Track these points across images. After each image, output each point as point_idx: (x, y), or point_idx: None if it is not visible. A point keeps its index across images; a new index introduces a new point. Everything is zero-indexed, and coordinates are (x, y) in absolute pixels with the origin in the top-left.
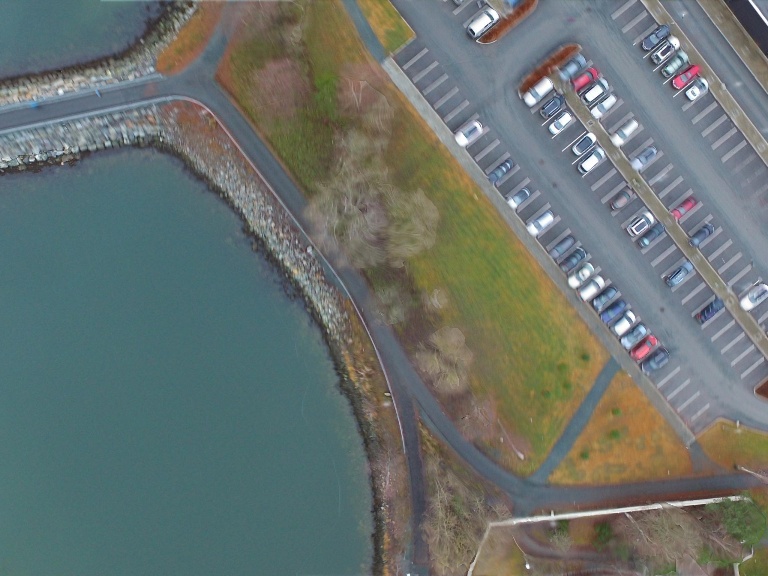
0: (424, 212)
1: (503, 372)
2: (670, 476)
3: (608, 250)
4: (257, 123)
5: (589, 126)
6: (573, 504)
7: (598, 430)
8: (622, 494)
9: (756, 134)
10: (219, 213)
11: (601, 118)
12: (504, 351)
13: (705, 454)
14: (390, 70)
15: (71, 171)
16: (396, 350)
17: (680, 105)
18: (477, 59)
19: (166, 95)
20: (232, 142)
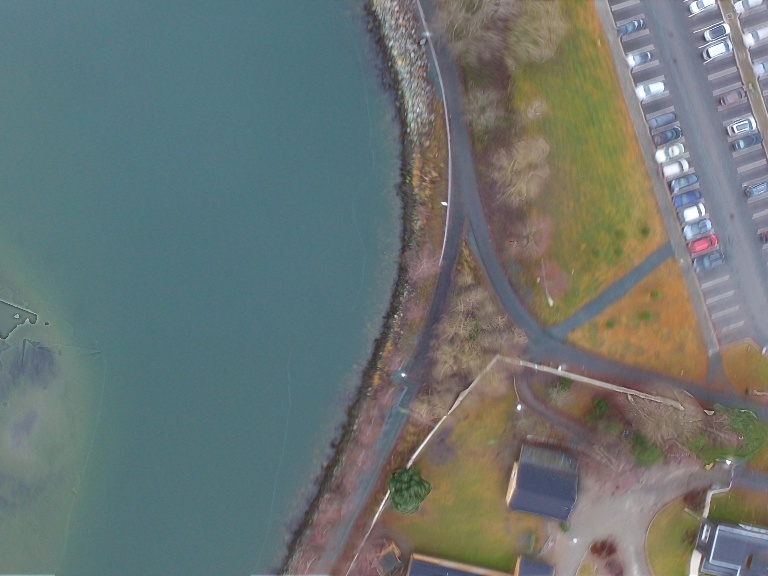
0: (554, 23)
1: (563, 216)
2: (682, 376)
3: (702, 140)
4: None
5: (727, 18)
6: (582, 368)
7: (632, 305)
8: (631, 376)
9: None
10: None
11: (741, 14)
12: (572, 196)
13: (723, 368)
14: None
15: None
16: (468, 166)
17: None
18: None
19: None
20: None
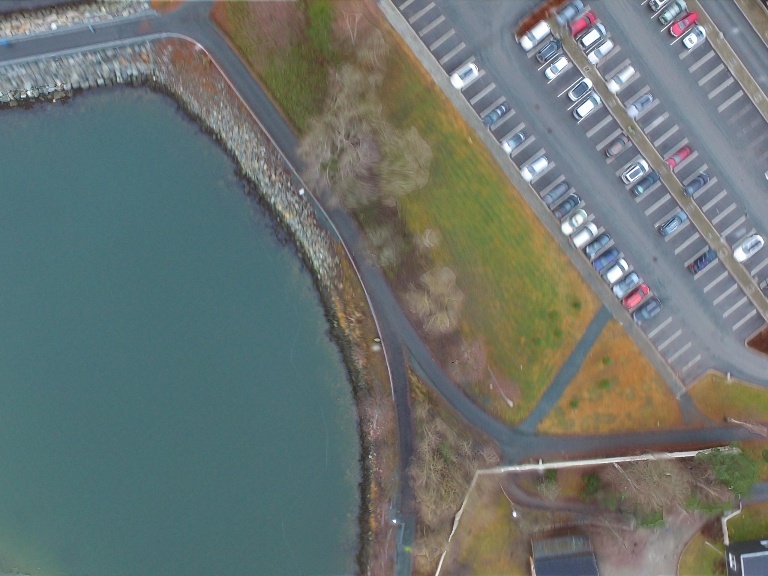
0: (417, 150)
1: (494, 318)
2: (660, 427)
3: (602, 197)
4: (251, 63)
5: (585, 72)
6: (562, 453)
7: (588, 379)
8: (611, 444)
9: (753, 84)
10: (211, 155)
11: (598, 64)
12: (495, 297)
13: (695, 406)
14: (386, 10)
15: (63, 109)
16: (387, 296)
17: (677, 53)
18: (474, 1)
19: (160, 32)
20: (226, 81)
